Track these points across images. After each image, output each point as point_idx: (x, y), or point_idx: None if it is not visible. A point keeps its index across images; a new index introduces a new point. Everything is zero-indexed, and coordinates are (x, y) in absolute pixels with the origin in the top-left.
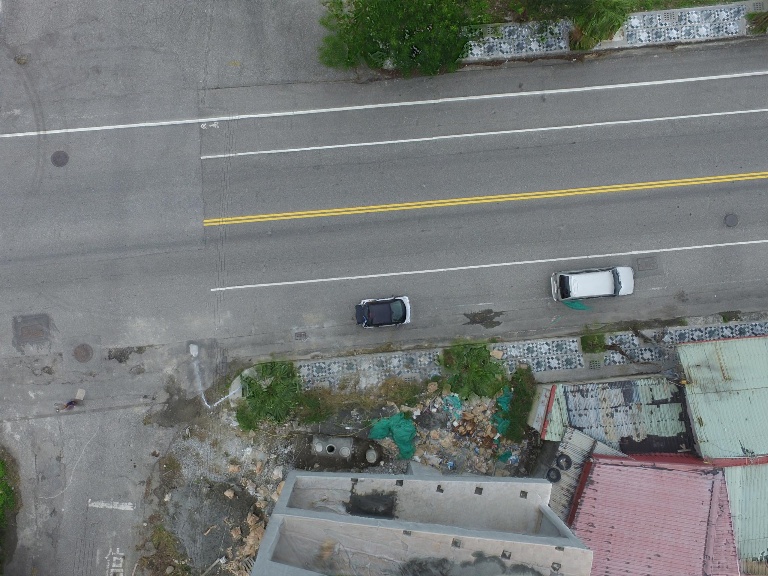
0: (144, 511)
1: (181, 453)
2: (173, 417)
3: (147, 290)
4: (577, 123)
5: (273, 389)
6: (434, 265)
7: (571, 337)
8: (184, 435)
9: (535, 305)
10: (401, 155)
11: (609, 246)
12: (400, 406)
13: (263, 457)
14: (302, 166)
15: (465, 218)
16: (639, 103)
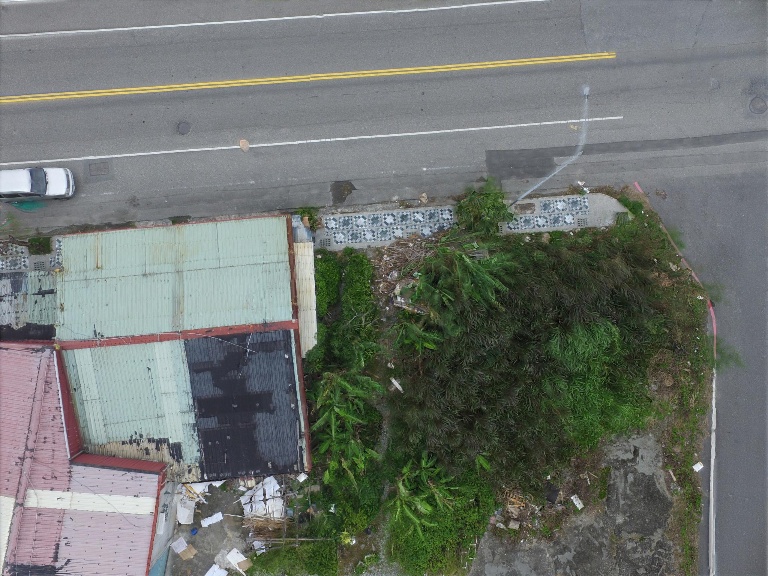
0: None
1: None
2: None
3: None
4: (34, 31)
5: None
6: None
7: (18, 239)
8: None
9: None
10: None
11: (62, 151)
12: None
13: None
14: None
15: None
16: (100, 14)
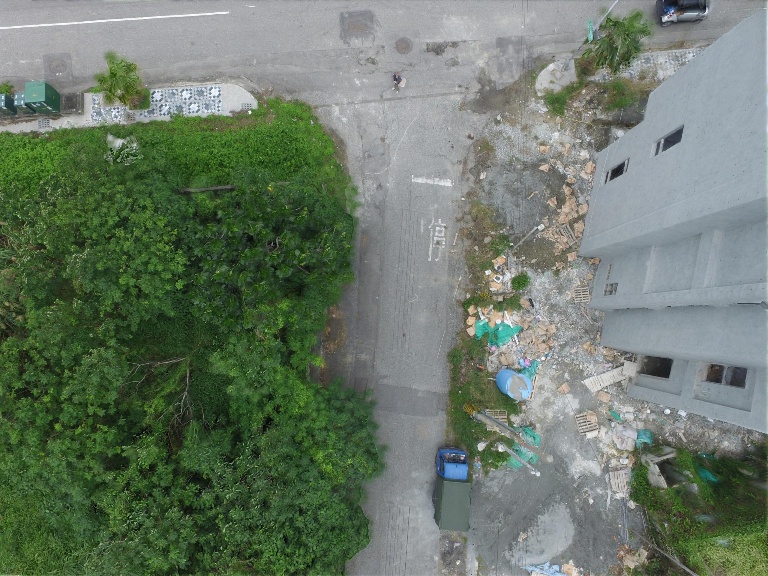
0: (462, 187)
1: (494, 137)
2: (485, 105)
3: None
4: None
5: None
6: None
7: None
8: (496, 121)
9: None
10: None
11: None
12: None
13: (570, 141)
14: None
15: None
16: None
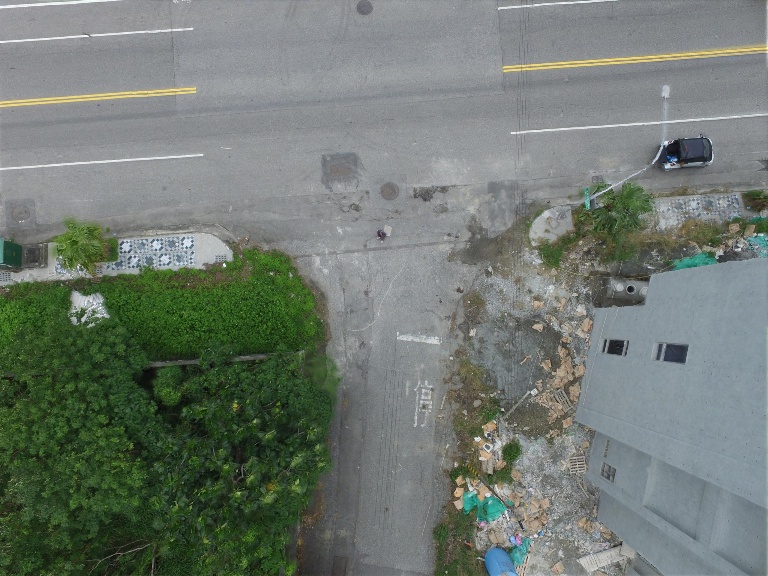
0: (450, 345)
1: (484, 290)
2: (475, 255)
3: (449, 132)
4: None
5: (627, 198)
6: (728, 112)
7: None
8: (487, 273)
9: None
10: (693, 7)
11: None
12: (702, 246)
13: (566, 295)
14: (598, 16)
15: (758, 67)
16: None
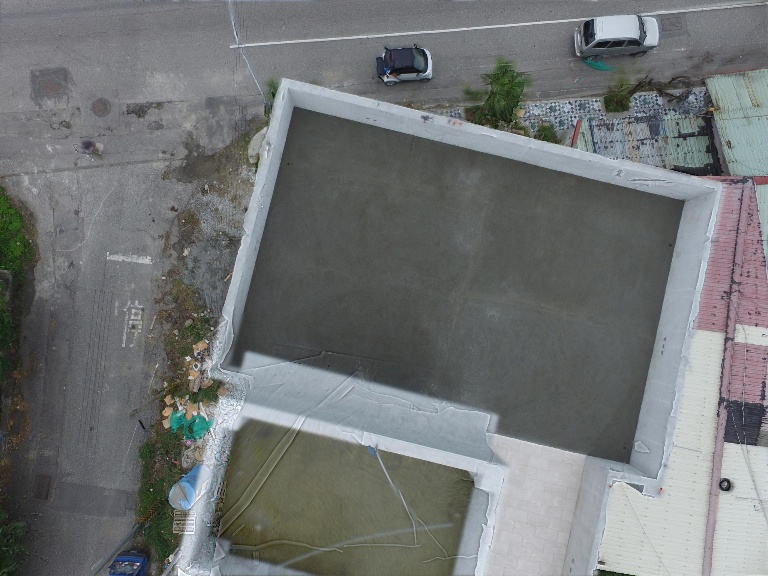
0: (163, 265)
1: (200, 209)
2: (192, 174)
3: (165, 46)
4: None
5: None
6: (456, 24)
7: (594, 97)
8: (203, 191)
9: (558, 66)
10: None
11: (633, 7)
12: None
13: None
14: None
15: None
16: None
